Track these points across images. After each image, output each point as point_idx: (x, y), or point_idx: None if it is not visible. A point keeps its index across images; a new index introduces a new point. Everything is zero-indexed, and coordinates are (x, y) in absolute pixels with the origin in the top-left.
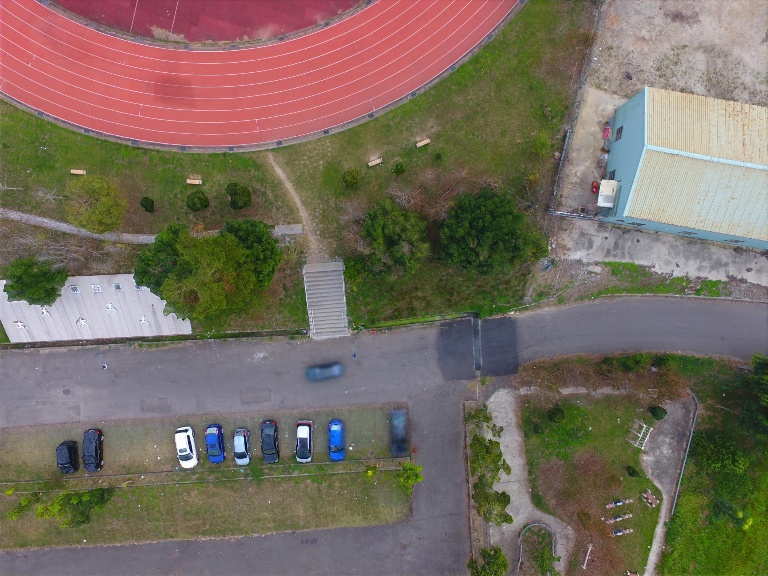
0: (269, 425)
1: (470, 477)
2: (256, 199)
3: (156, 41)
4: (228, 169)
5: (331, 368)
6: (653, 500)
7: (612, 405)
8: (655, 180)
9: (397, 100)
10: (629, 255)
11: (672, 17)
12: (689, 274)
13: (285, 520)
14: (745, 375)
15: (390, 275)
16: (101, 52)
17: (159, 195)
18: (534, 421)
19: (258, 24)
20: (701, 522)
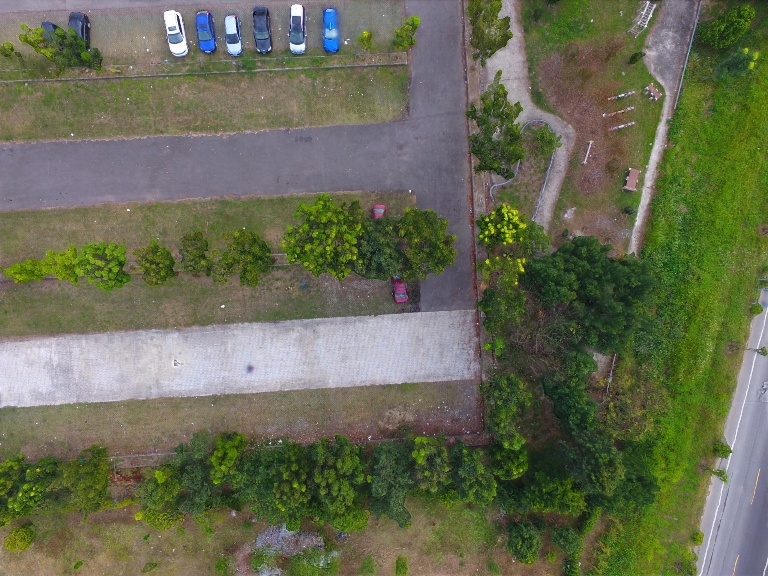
0: (261, 8)
1: (468, 72)
2: None
3: None
4: None
5: None
6: (655, 93)
7: None
8: None
9: None
10: None
11: None
12: None
13: (279, 117)
14: None
15: None
16: None
17: None
18: None
19: None
20: (704, 112)
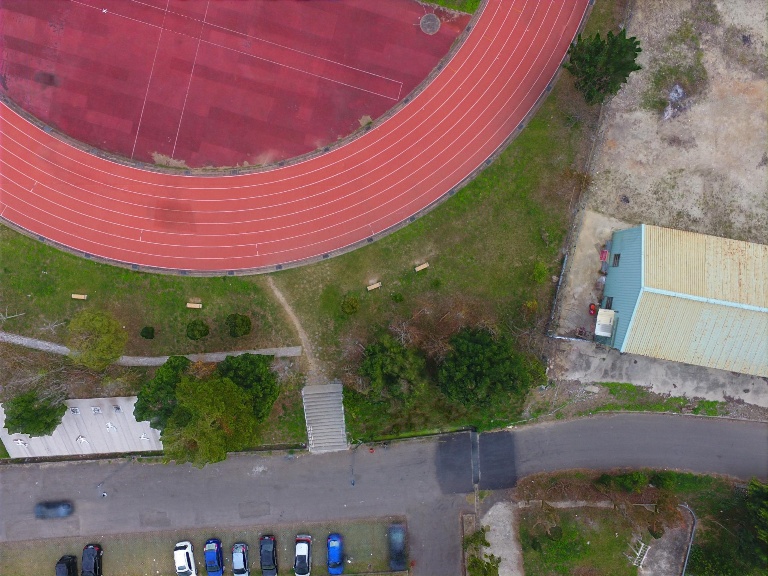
0: (268, 541)
1: None
2: (256, 322)
3: (157, 167)
4: (228, 292)
5: (330, 482)
6: None
7: (610, 519)
8: (652, 319)
9: (396, 224)
10: (627, 376)
11: (669, 141)
12: (686, 394)
13: None
14: (742, 495)
15: (389, 408)
16: (102, 178)
17: (159, 318)
18: (532, 535)
19: (258, 150)
20: None
